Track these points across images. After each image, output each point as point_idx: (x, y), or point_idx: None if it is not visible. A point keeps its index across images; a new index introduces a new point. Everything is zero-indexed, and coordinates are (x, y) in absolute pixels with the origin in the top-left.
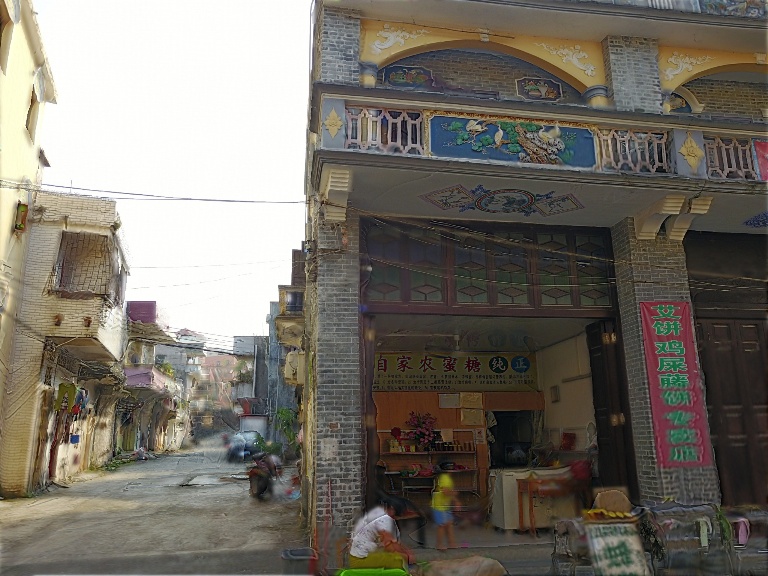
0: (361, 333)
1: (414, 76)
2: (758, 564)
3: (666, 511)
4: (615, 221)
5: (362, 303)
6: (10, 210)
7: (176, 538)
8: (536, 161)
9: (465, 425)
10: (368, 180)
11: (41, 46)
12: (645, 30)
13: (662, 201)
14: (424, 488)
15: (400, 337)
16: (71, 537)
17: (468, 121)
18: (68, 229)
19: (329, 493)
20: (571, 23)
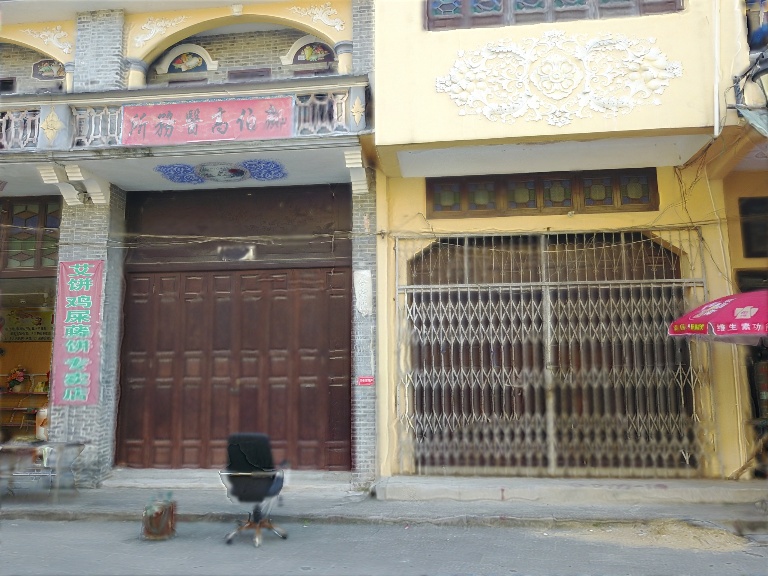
0: None
1: None
2: (10, 484)
3: None
4: None
5: None
6: None
7: None
8: None
9: None
10: None
11: None
12: (101, 3)
13: None
14: None
15: None
16: None
17: None
18: None
19: None
20: (32, 8)
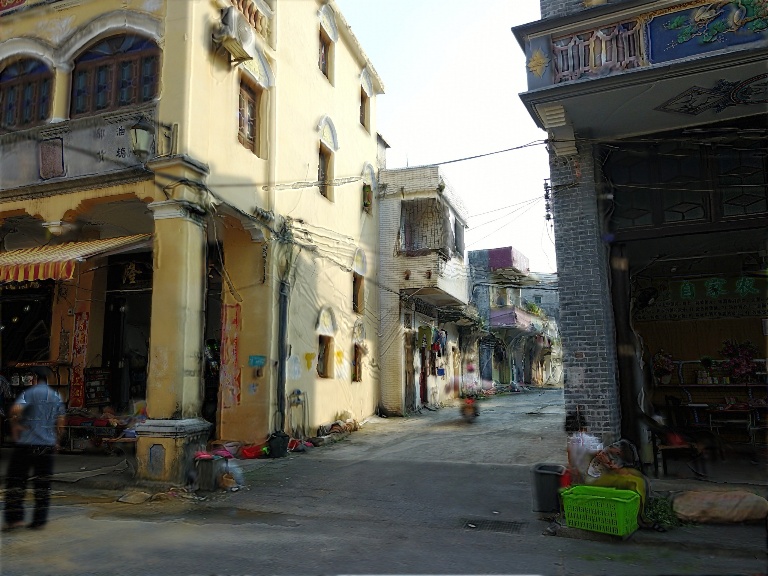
0: (602, 264)
1: None
2: None
3: None
4: None
5: (609, 233)
6: (357, 193)
7: (482, 452)
8: None
9: None
10: (586, 109)
11: (361, 51)
12: None
13: None
14: (738, 423)
15: (699, 259)
16: (410, 446)
17: (697, 10)
18: (405, 198)
19: (577, 418)
20: None
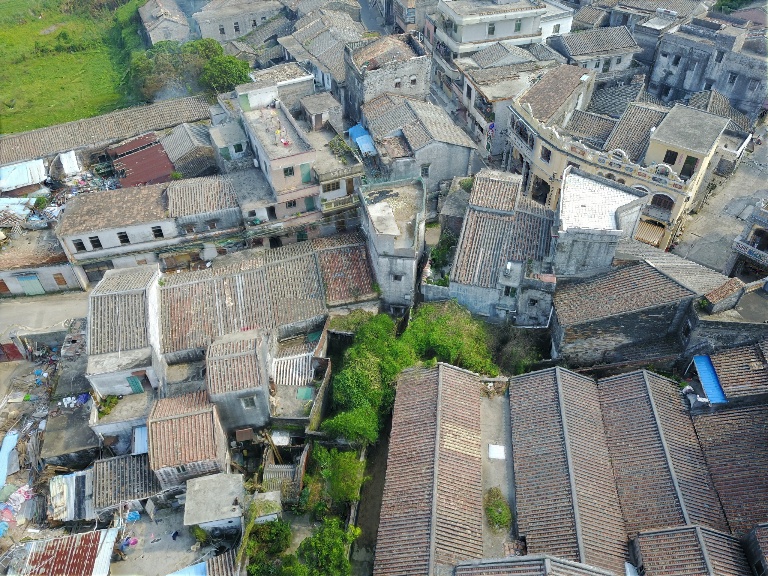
0: None
1: None
2: None
3: None
4: None
5: None
6: None
7: None
8: None
9: None
10: None
11: None
12: None
13: None
14: None
15: None
16: None
17: None
18: (723, 158)
19: None
20: None
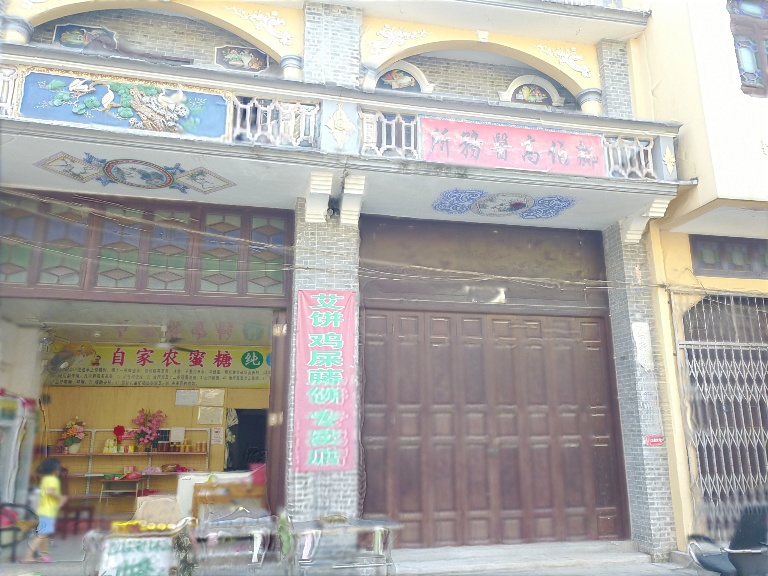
0: None
1: (94, 37)
2: None
3: (222, 522)
4: (292, 202)
5: None
6: None
7: None
8: (151, 128)
9: (198, 424)
10: None
11: None
12: None
13: (310, 179)
14: (128, 492)
15: (124, 327)
16: None
17: (73, 80)
18: None
19: None
20: None
